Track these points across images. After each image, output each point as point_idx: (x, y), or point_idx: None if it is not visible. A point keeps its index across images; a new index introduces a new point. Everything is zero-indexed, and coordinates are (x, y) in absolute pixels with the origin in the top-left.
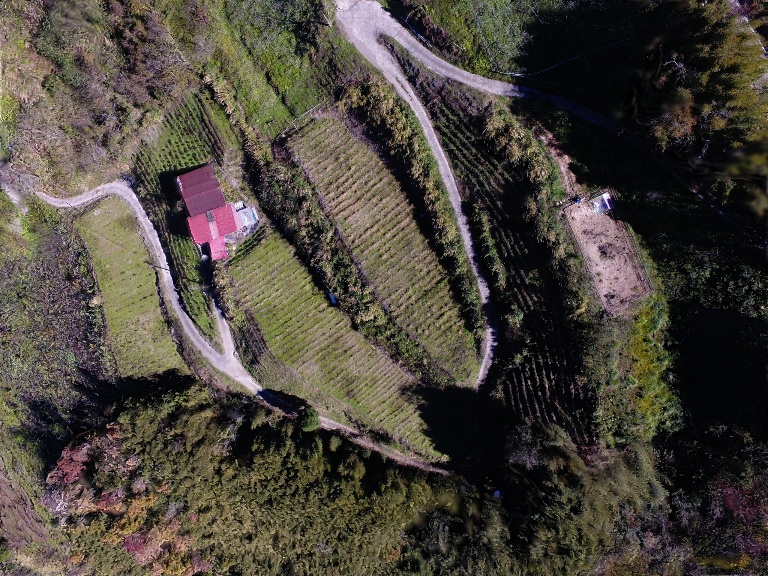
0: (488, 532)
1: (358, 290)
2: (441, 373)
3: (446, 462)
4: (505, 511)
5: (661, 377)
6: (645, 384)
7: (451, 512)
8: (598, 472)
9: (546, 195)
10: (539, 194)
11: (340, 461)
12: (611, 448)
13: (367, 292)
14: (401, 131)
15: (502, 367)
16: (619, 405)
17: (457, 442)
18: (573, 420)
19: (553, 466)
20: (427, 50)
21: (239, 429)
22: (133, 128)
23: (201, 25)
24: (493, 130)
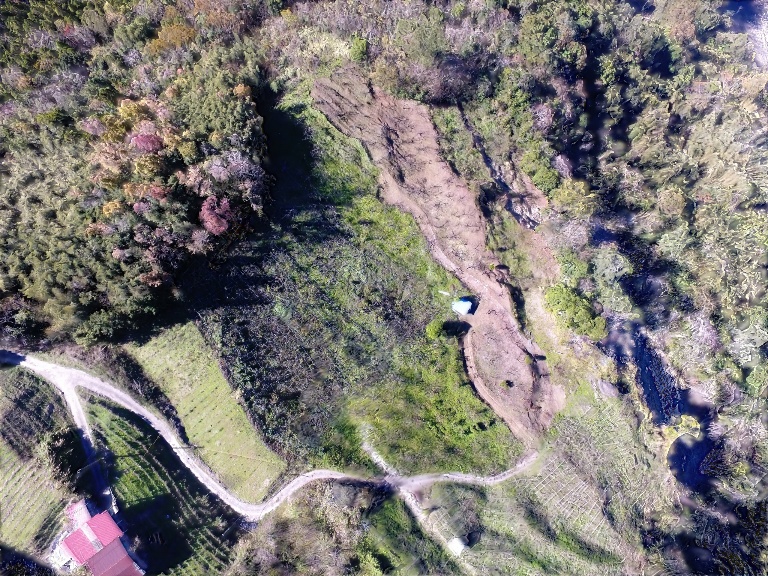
0: None
1: None
2: None
3: None
4: None
5: None
6: None
7: None
8: None
9: None
10: None
11: None
12: None
13: None
14: None
15: None
16: None
17: None
18: None
19: None
20: None
21: (1, 331)
22: None
23: None
24: None
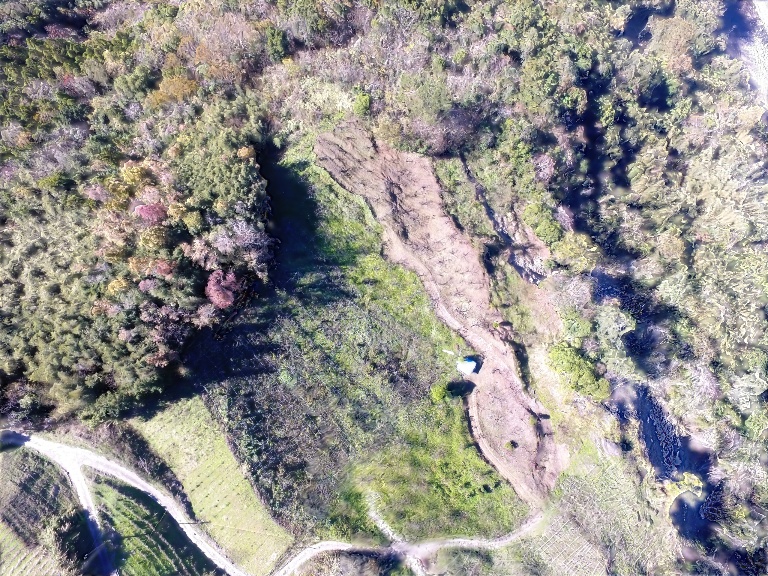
0: None
1: None
2: None
3: None
4: None
5: None
6: None
7: None
8: None
9: None
10: None
11: None
12: None
13: None
14: None
15: None
16: None
17: None
18: None
19: None
20: None
21: (6, 417)
22: None
23: None
24: None
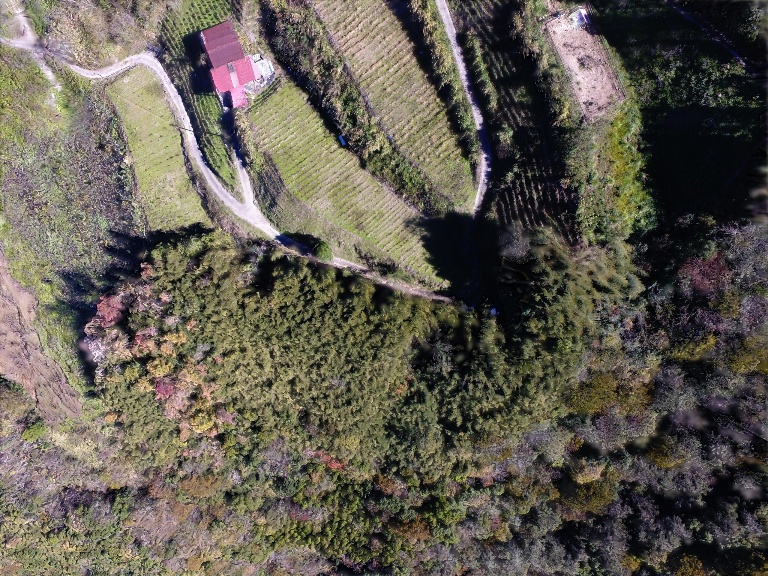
0: (486, 355)
1: (365, 121)
2: (441, 199)
3: (447, 288)
4: (501, 327)
5: (635, 177)
6: (621, 183)
7: (453, 340)
8: (582, 268)
9: (530, 11)
10: (524, 10)
11: (352, 285)
12: (593, 245)
13: (374, 122)
14: None
15: (495, 188)
16: (599, 203)
17: (457, 268)
18: (559, 224)
19: (541, 258)
20: None
21: (260, 261)
22: None
23: None
24: None
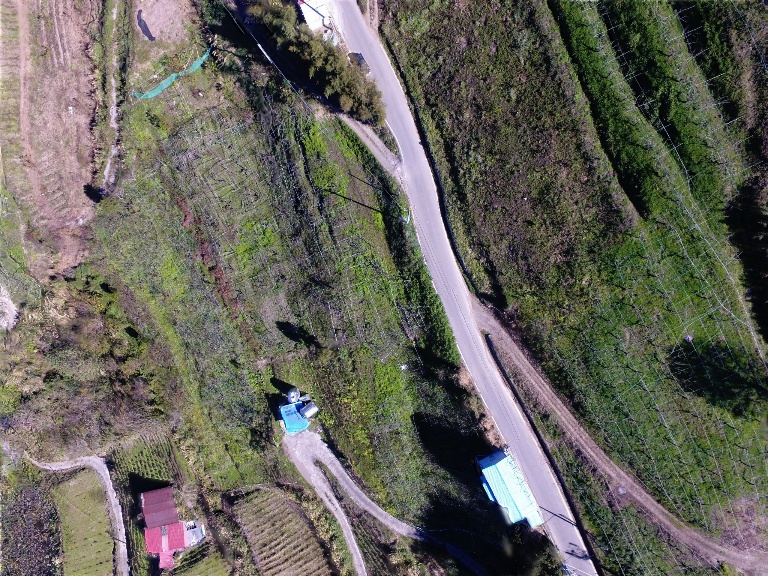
0: None
1: None
2: None
3: None
4: None
5: None
6: None
7: None
8: None
9: None
10: None
11: None
12: None
13: None
14: (324, 533)
15: None
16: None
17: None
18: None
19: None
20: (352, 482)
21: None
22: (112, 439)
23: (178, 398)
24: (396, 560)
